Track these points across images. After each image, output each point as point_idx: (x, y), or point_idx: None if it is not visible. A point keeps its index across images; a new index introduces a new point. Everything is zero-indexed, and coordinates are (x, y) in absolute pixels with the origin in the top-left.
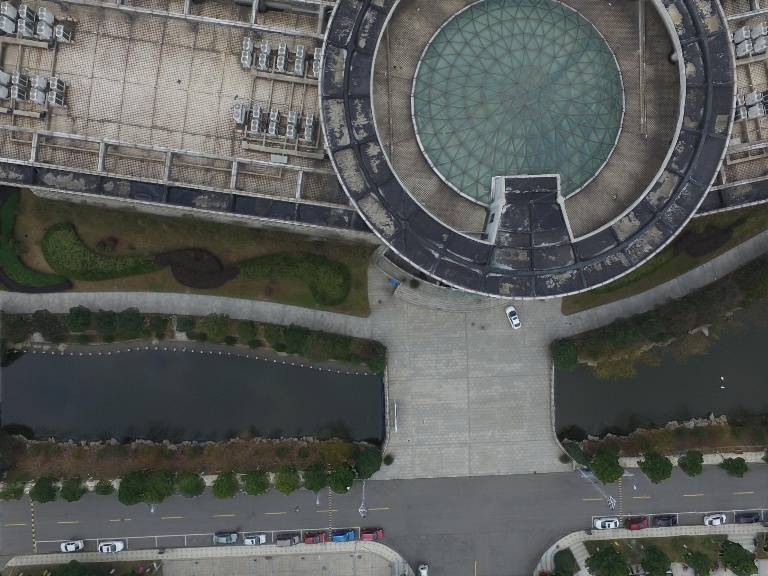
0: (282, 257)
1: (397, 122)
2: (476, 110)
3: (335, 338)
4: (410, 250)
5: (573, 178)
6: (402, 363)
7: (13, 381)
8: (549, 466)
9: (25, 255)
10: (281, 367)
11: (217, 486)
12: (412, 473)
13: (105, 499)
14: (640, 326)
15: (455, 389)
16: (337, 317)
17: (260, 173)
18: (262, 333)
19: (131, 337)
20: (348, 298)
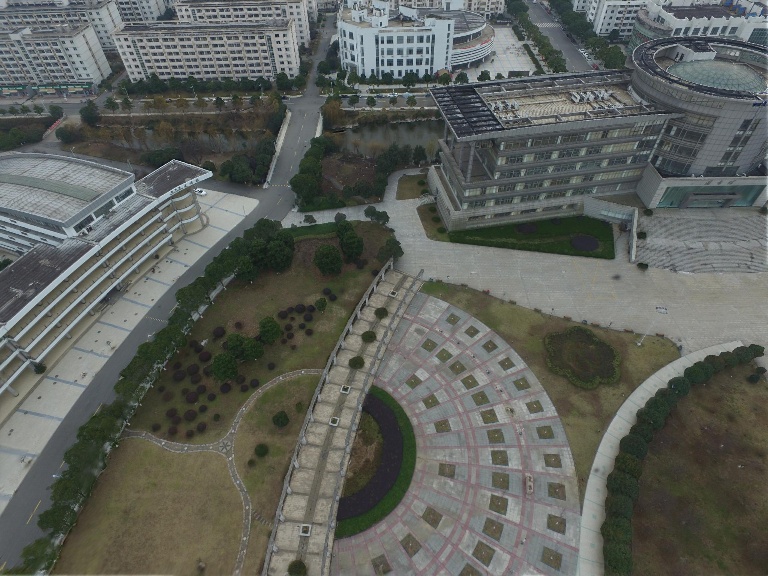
0: None
1: None
2: None
3: None
4: None
5: None
6: None
7: None
8: None
9: None
10: None
11: None
12: None
13: None
14: None
15: None
16: None
17: None
18: None
19: None
20: None
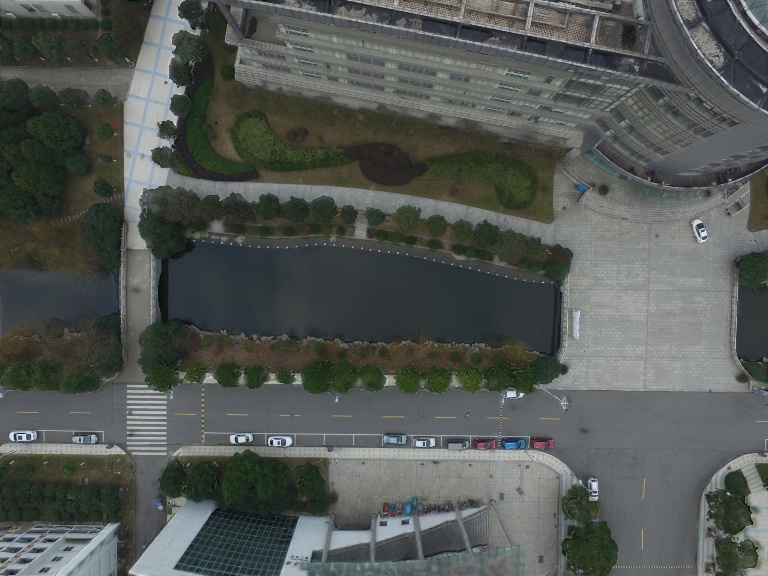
0: (471, 156)
1: None
2: None
3: (526, 238)
4: (738, 83)
5: None
6: (583, 272)
7: (180, 276)
8: (725, 385)
9: (214, 142)
10: (457, 271)
11: (405, 378)
12: (586, 384)
13: (276, 393)
14: None
15: (635, 301)
16: (520, 221)
17: (544, 22)
18: (444, 234)
19: (313, 230)
20: (533, 203)
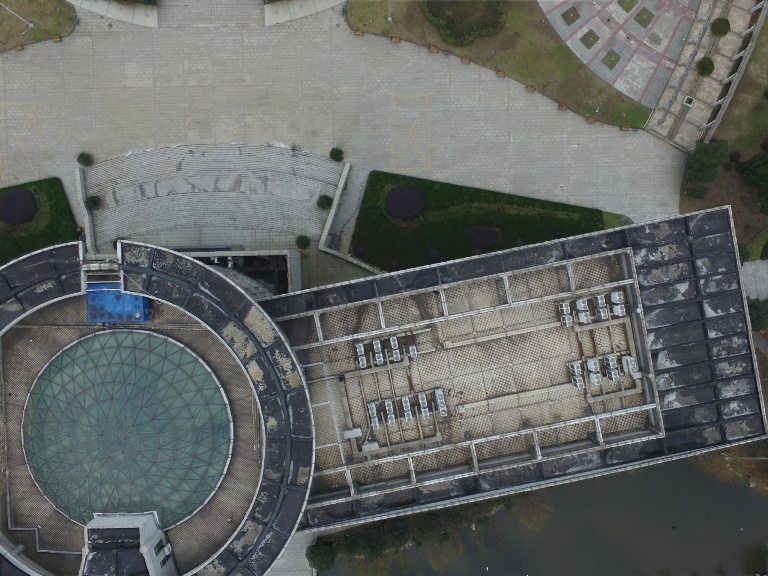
0: None
1: (13, 447)
2: (67, 456)
3: None
4: None
5: (177, 511)
6: None
7: None
8: None
9: None
10: None
11: None
12: None
13: None
14: (387, 537)
15: None
16: None
17: None
18: None
19: None
20: None
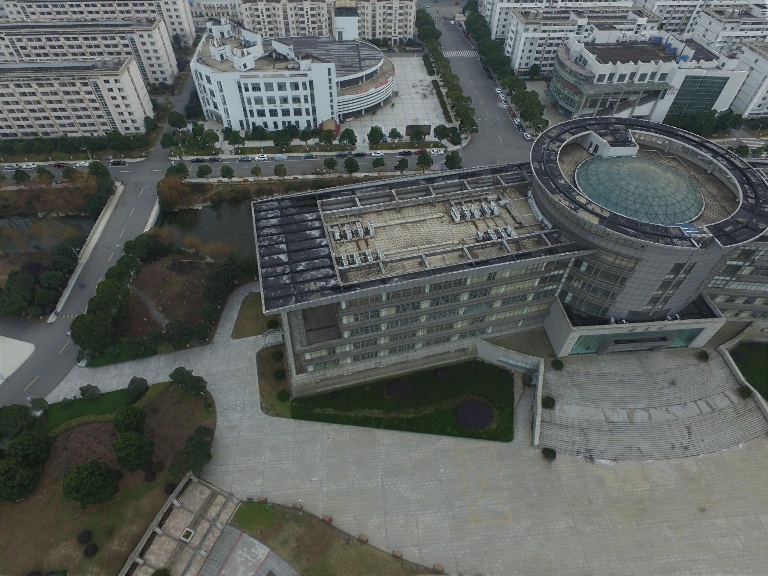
0: None
1: None
2: None
3: None
4: None
5: None
6: None
7: None
8: None
9: None
10: None
11: None
12: None
13: None
14: None
15: None
16: None
17: None
18: None
19: None
20: None
